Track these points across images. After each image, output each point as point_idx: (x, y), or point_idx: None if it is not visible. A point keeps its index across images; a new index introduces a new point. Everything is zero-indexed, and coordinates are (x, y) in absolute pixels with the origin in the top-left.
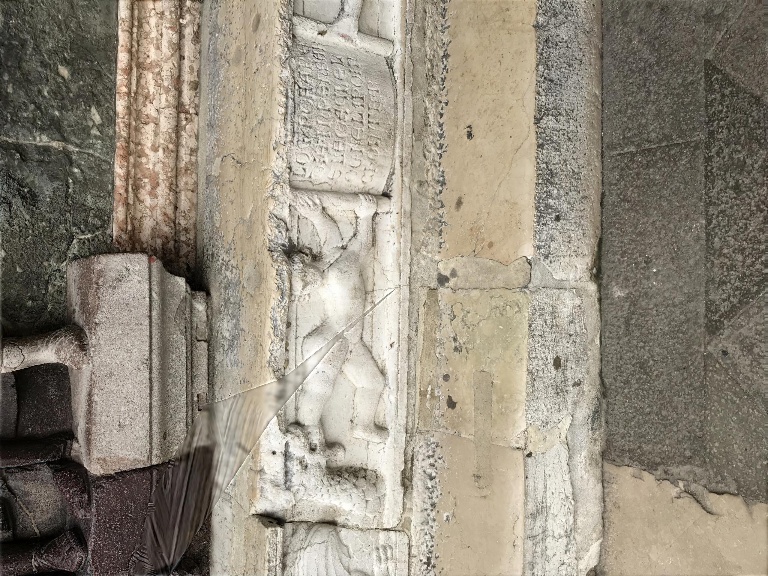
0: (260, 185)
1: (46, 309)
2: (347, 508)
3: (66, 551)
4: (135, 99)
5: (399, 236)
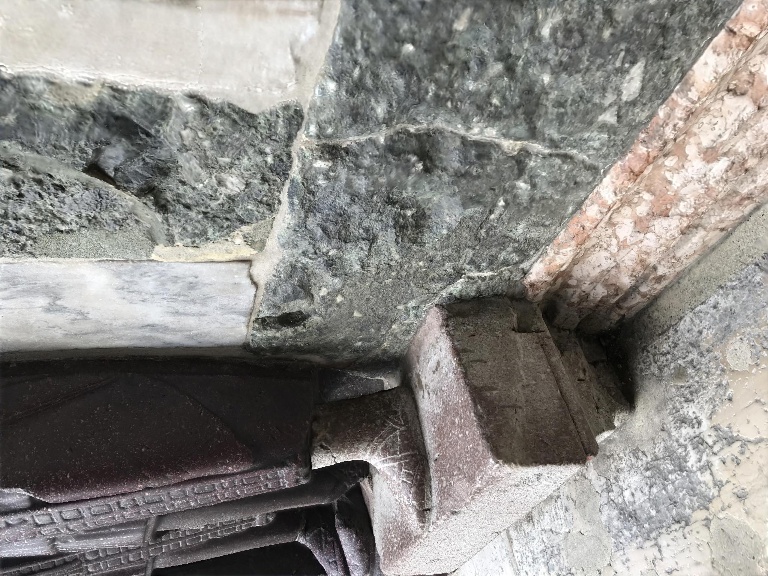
0: None
1: (379, 346)
2: None
3: (332, 575)
4: (759, 40)
5: None
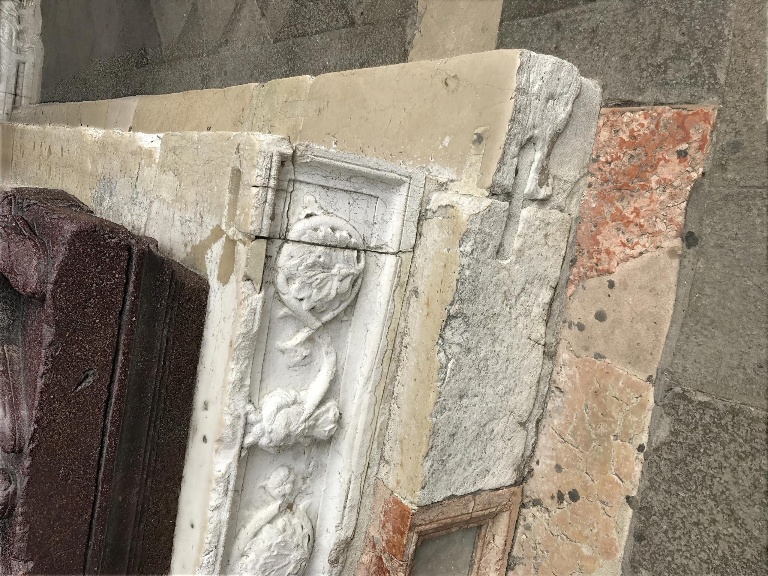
0: None
1: None
2: None
3: None
4: None
5: None
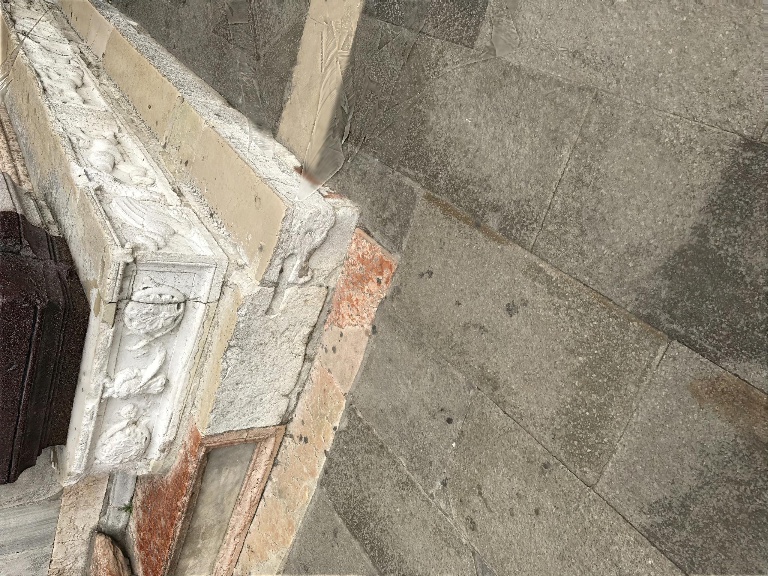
0: (47, 130)
1: None
2: (139, 195)
3: None
4: None
5: (131, 137)
